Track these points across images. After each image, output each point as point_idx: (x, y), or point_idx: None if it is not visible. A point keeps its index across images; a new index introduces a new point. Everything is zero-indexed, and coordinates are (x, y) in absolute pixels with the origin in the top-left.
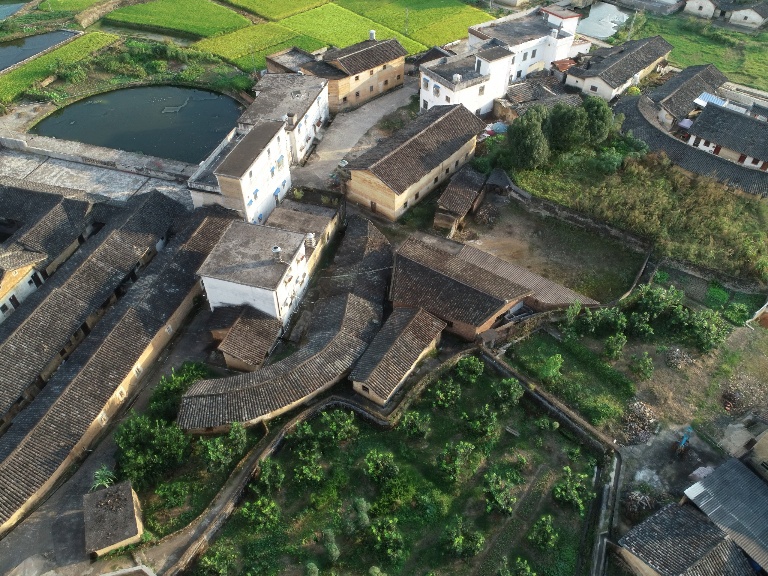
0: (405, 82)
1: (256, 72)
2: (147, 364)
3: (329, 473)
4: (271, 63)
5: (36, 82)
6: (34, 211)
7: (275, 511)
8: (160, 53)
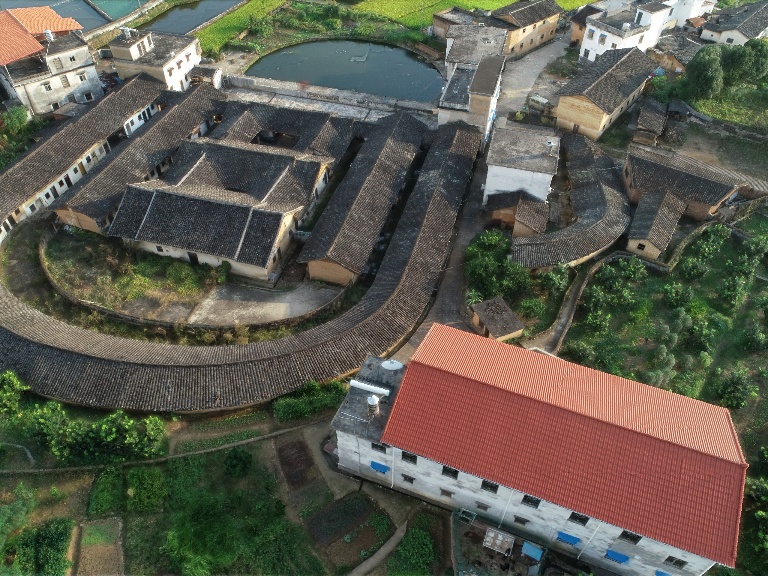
0: (554, 38)
1: (421, 29)
2: None
3: None
4: (439, 20)
5: (236, 35)
6: (306, 127)
7: (608, 321)
8: (333, 12)
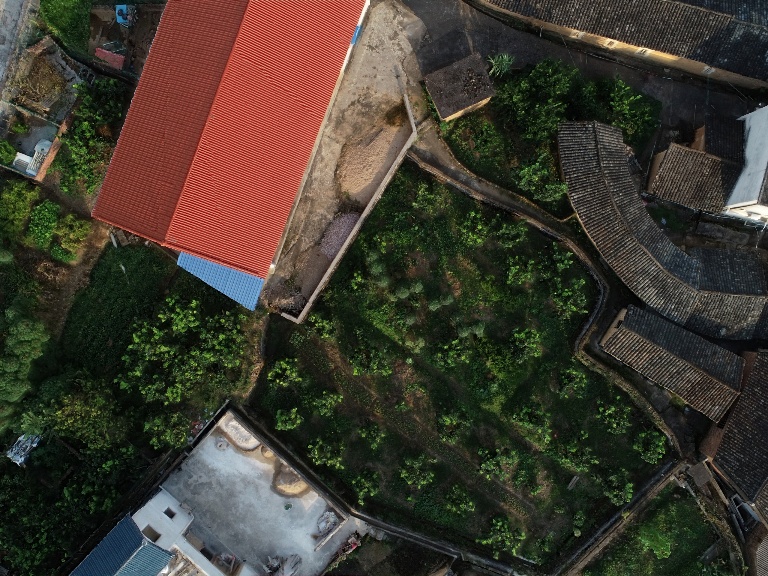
0: None
1: None
2: (656, 58)
3: (520, 290)
4: None
5: None
6: None
7: (475, 243)
8: None
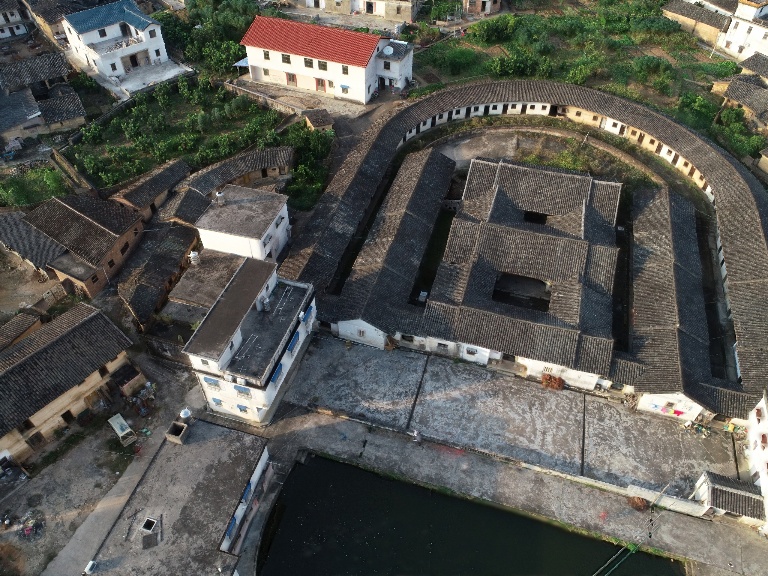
0: None
1: None
2: None
3: None
4: None
5: None
6: (489, 305)
7: None
8: None
